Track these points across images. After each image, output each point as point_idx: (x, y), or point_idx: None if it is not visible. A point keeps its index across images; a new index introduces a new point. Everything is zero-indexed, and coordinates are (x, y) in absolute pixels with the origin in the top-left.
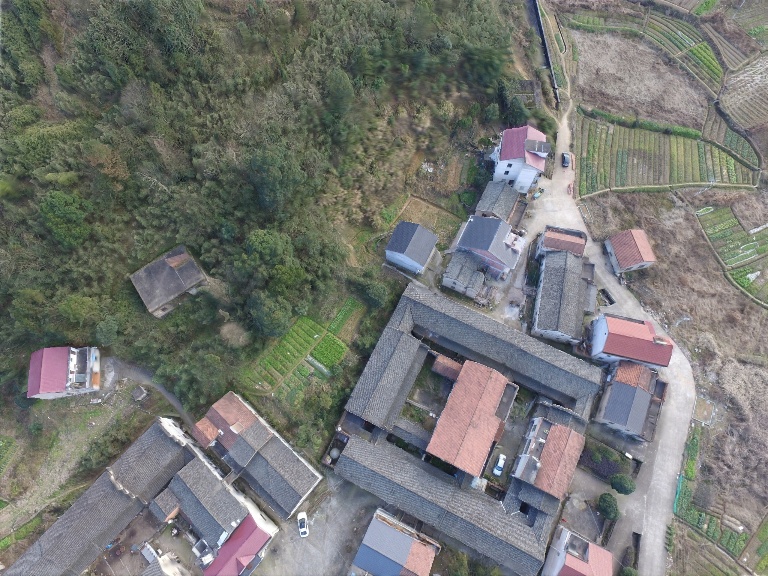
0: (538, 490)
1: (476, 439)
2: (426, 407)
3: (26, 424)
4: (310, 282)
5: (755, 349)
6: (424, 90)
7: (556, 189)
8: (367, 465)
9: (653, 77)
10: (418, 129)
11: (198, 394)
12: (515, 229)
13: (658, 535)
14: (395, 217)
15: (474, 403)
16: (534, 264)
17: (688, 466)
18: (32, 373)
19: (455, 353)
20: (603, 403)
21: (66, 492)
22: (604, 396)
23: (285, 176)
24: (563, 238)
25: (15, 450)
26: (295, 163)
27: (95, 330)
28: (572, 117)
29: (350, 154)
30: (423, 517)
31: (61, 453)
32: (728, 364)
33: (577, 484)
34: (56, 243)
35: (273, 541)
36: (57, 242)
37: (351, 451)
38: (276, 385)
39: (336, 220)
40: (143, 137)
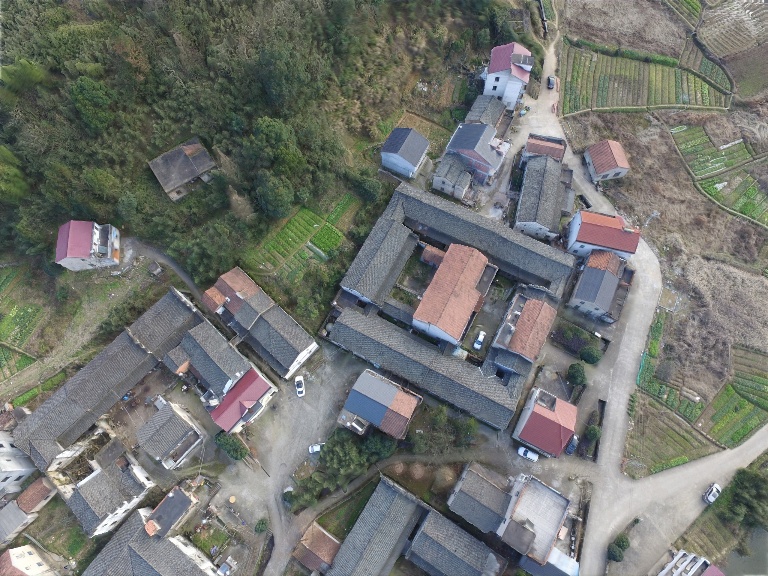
0: (512, 354)
1: (457, 307)
2: (414, 291)
3: (52, 294)
4: (311, 173)
5: (719, 248)
6: (421, 14)
7: (541, 108)
8: (359, 330)
9: (636, 12)
10: (414, 49)
11: (208, 270)
12: (501, 138)
13: (622, 402)
14: (391, 130)
15: (456, 276)
16: (518, 172)
17: (652, 345)
18: (60, 242)
19: (442, 246)
20: (576, 288)
21: (88, 352)
22: (577, 283)
23: (290, 72)
24: (544, 144)
25: (42, 316)
26: (300, 62)
27: (117, 208)
28: (559, 46)
29: (350, 66)
30: (408, 375)
31: (84, 319)
32: (693, 260)
33: (550, 358)
34: (83, 127)
35: (273, 400)
36: (84, 127)
37: (345, 319)
38: (278, 266)
39: (336, 126)
40: (163, 38)
